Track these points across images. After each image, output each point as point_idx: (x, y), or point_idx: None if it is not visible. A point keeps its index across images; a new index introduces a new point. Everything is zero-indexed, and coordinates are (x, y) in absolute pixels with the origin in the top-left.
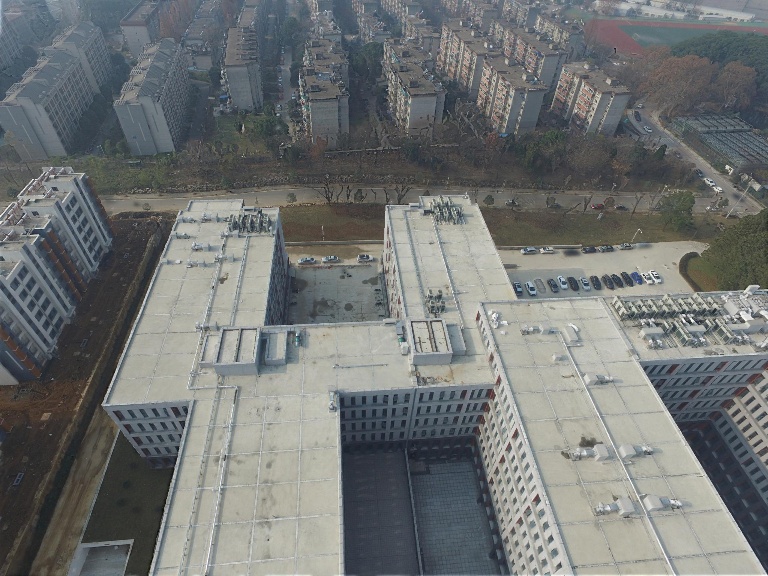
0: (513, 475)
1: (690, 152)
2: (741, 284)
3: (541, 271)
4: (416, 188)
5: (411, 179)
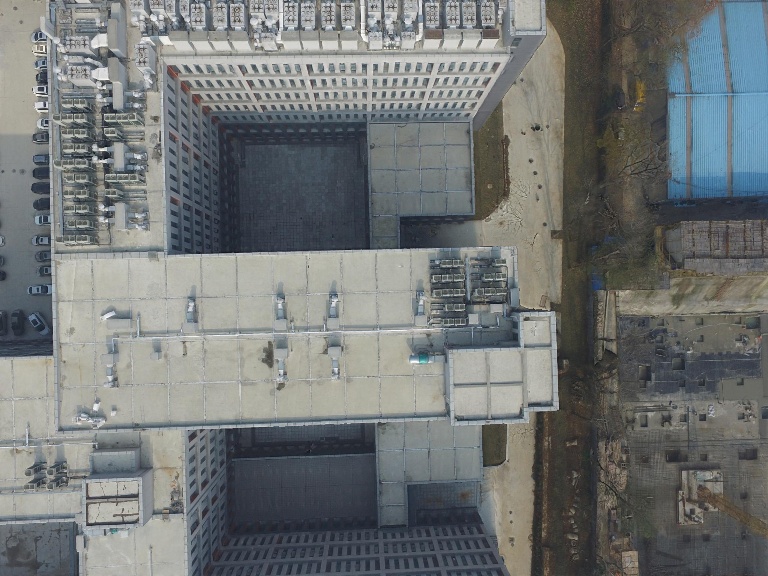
0: None
1: None
2: None
3: None
4: None
5: None
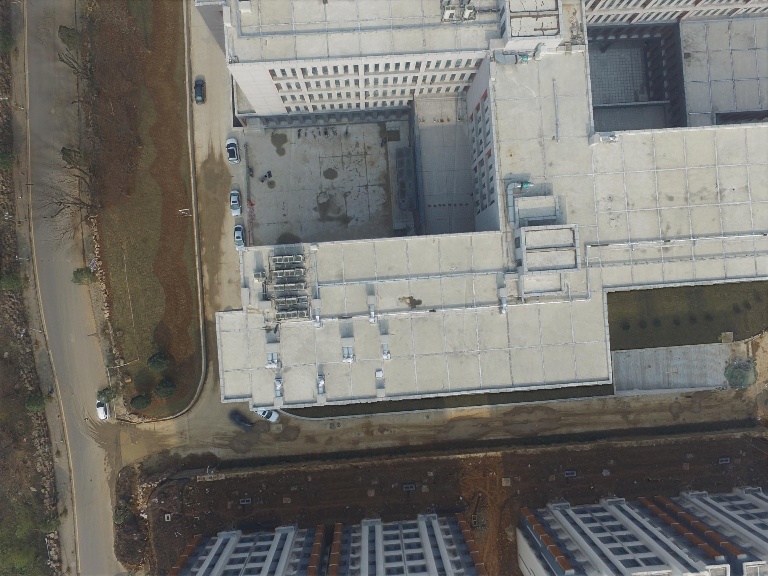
0: None
1: None
2: None
3: None
4: (23, 58)
5: None
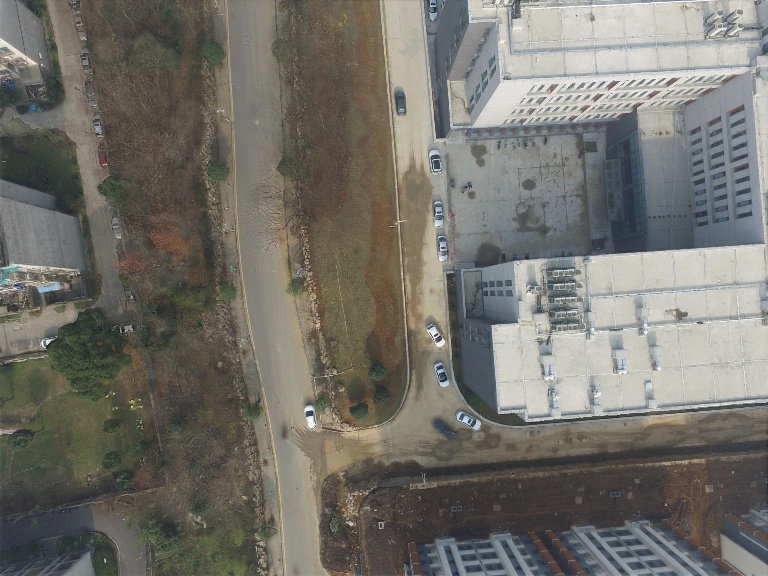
0: None
1: None
2: None
3: None
4: (227, 70)
5: (207, 74)
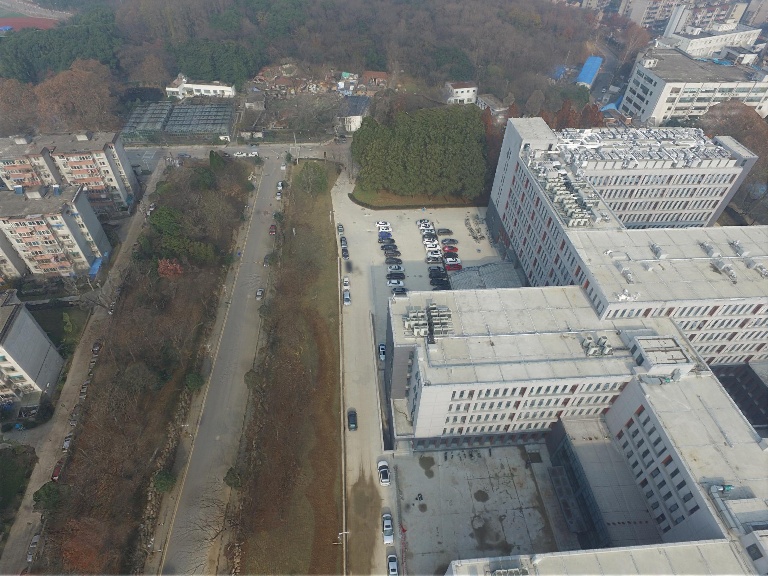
0: (720, 329)
1: (182, 148)
2: (427, 179)
3: (377, 296)
4: (203, 395)
5: (185, 398)
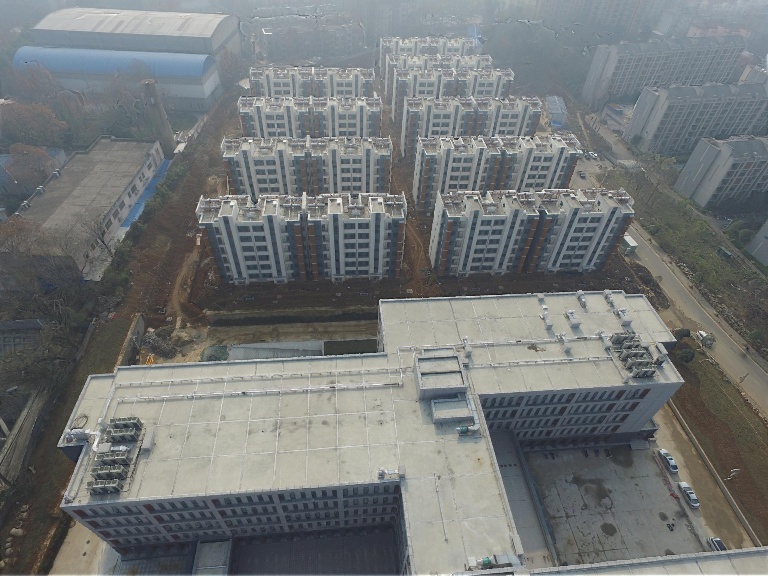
0: None
1: None
2: None
3: None
4: None
5: None
